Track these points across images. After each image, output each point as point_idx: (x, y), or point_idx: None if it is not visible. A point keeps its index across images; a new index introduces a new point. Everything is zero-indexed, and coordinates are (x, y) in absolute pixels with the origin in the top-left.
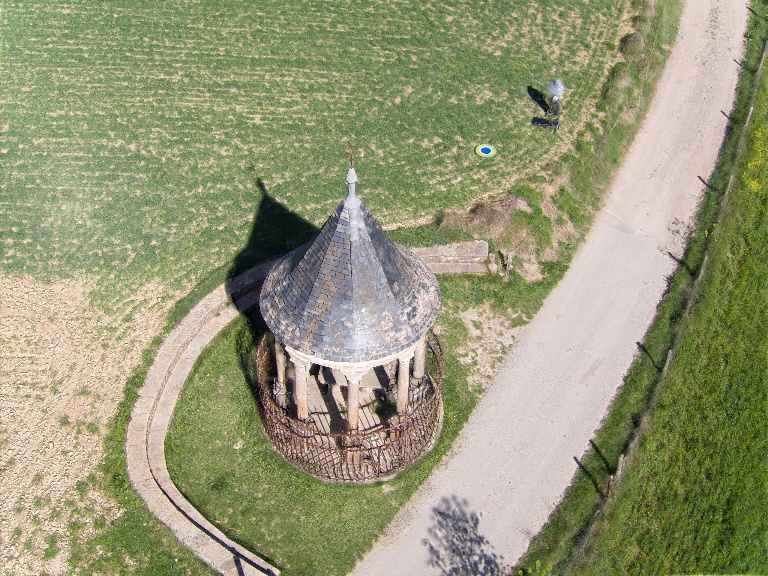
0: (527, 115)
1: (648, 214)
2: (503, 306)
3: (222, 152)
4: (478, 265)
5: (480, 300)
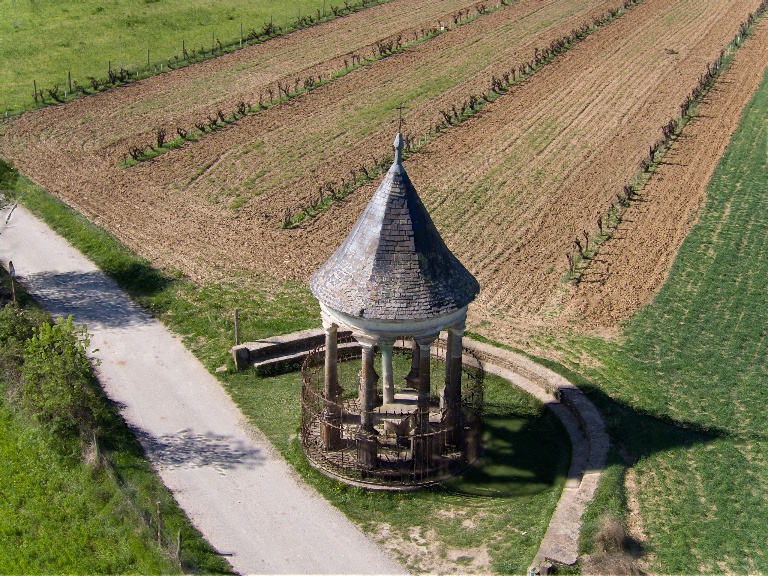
0: None
1: None
2: None
3: None
4: None
5: (499, 567)
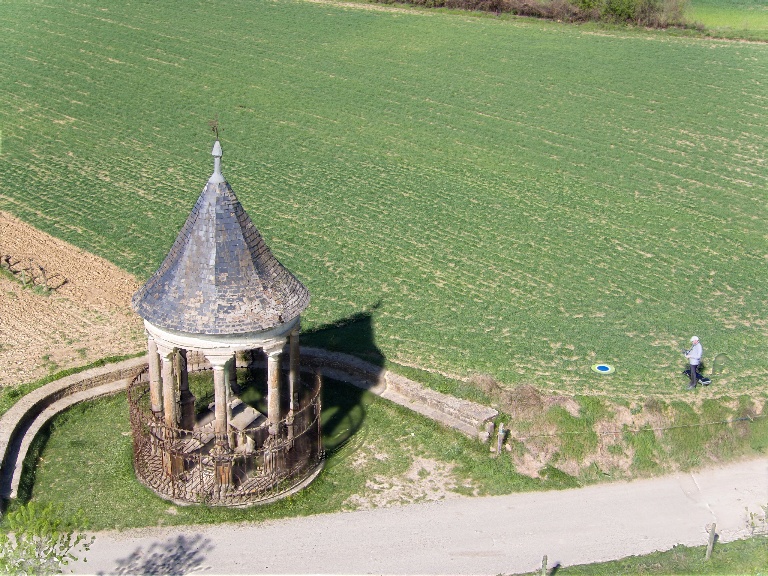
0: (688, 367)
1: (739, 500)
2: (466, 474)
3: (385, 289)
4: (474, 429)
5: (449, 457)
